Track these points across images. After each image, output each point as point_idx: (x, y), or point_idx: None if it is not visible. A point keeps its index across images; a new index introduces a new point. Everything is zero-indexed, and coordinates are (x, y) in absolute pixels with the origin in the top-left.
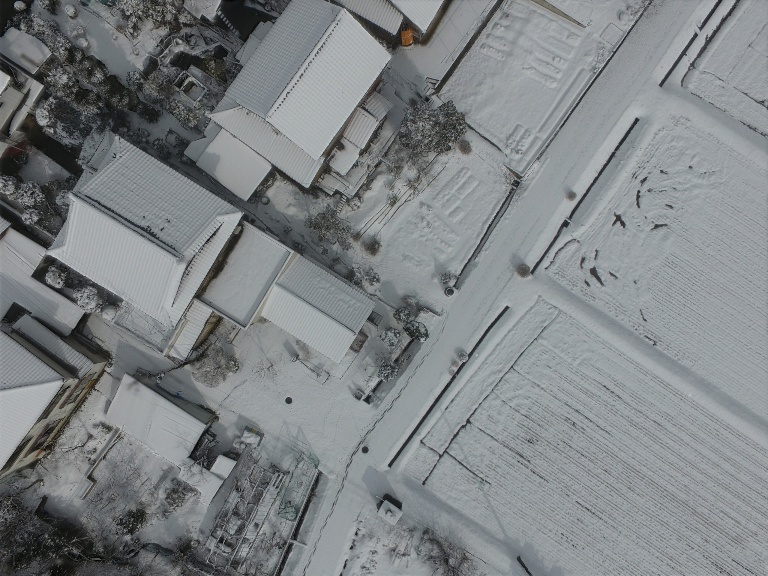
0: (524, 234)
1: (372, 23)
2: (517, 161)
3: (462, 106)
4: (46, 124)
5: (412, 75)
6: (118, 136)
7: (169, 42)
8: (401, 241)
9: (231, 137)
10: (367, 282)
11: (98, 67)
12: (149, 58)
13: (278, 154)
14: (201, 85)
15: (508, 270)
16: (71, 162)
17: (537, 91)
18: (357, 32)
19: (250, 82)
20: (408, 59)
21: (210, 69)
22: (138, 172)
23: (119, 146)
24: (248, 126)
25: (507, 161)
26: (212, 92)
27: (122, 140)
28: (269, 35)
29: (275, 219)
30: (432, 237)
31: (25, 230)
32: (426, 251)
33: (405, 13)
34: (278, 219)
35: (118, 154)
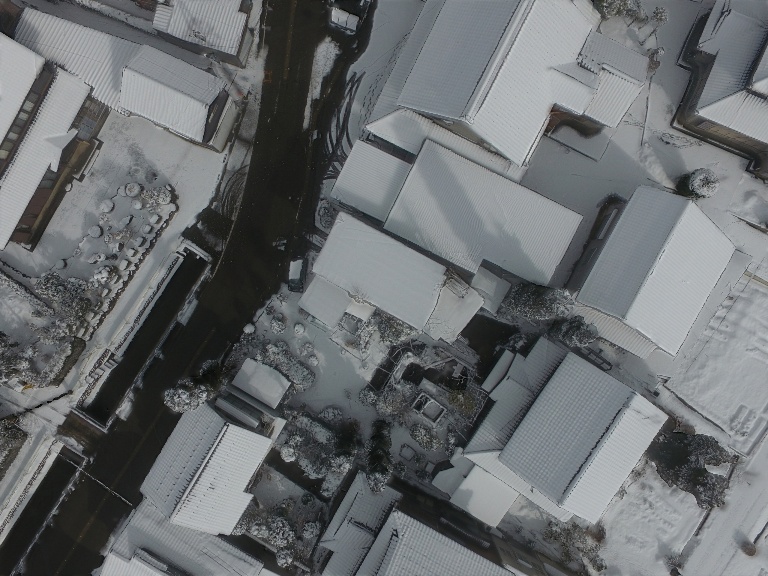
0: (747, 510)
1: (620, 347)
2: (742, 442)
3: (684, 388)
4: (291, 460)
5: (644, 375)
6: (397, 511)
7: (398, 354)
8: (624, 523)
9: (484, 472)
10: (595, 570)
11: (389, 464)
12: (377, 369)
13: (536, 492)
14: (441, 407)
15: (731, 546)
16: (303, 477)
17: (761, 371)
18: (644, 408)
19: (529, 453)
20: (639, 358)
21: (459, 404)
22: (422, 552)
23: (399, 523)
24: (505, 467)
25: (731, 442)
26: (449, 409)
27: (400, 514)
28: (543, 400)
29: (508, 522)
30: (655, 517)
31: (263, 551)
32: (649, 532)
33: (662, 347)
34: (511, 521)
35: (400, 533)
